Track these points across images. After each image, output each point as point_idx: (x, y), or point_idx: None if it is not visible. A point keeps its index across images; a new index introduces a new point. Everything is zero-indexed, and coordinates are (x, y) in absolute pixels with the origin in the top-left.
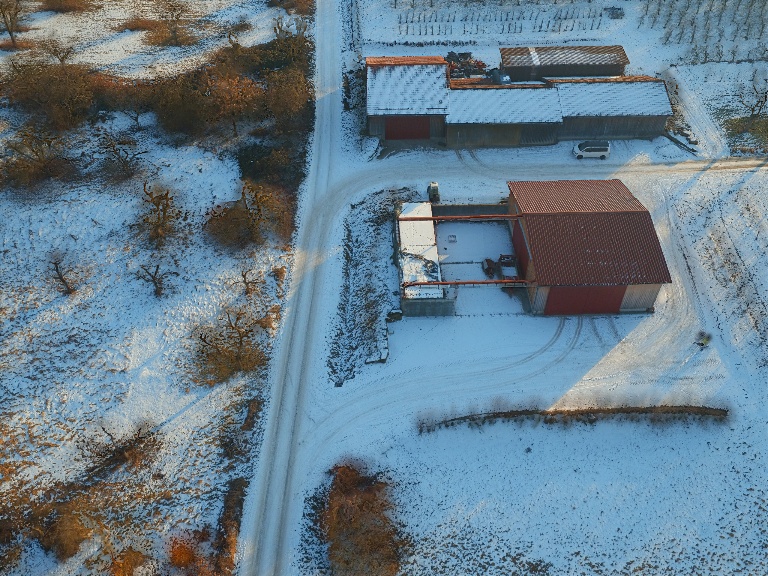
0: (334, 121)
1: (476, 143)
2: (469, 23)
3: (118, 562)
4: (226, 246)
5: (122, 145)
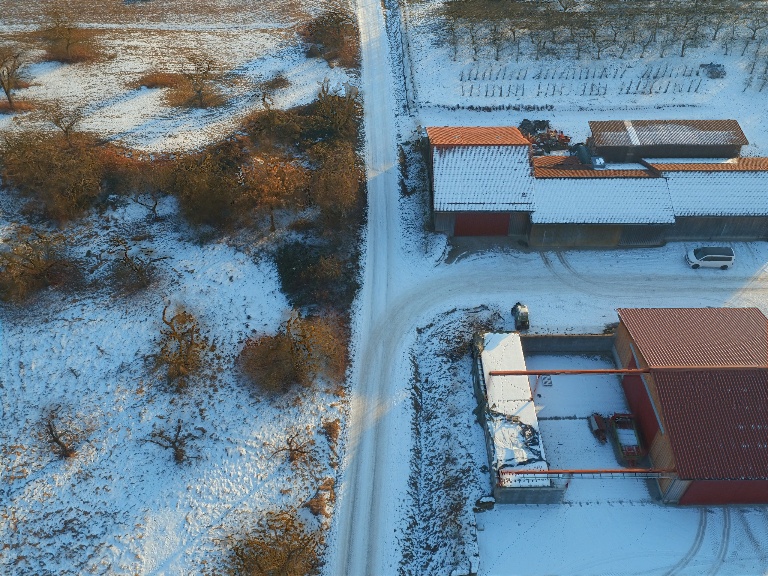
0: (390, 210)
1: (565, 244)
2: (542, 81)
3: None
4: (264, 389)
5: (136, 242)
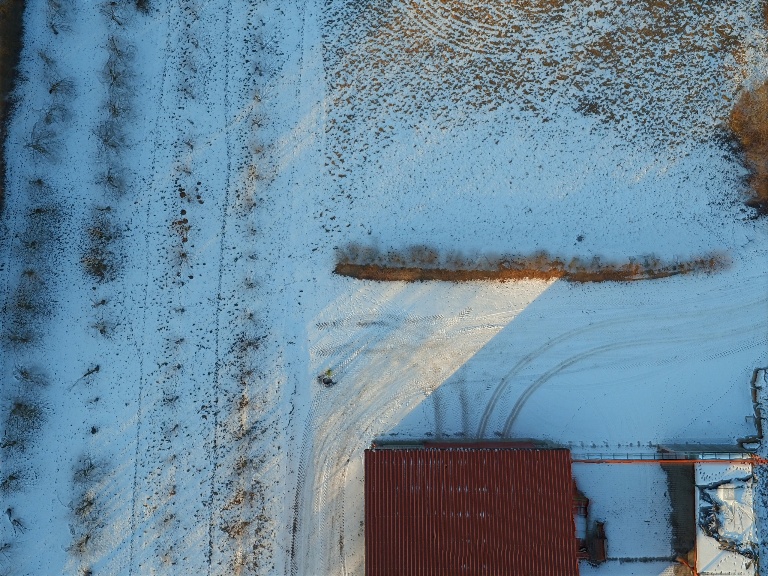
0: None
1: None
2: None
3: None
4: None
5: None
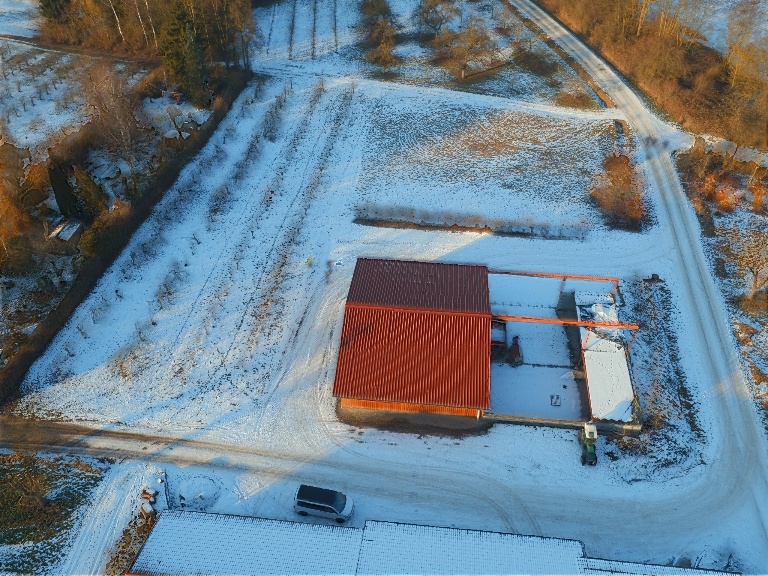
0: None
1: None
2: None
3: (766, 212)
4: None
5: None
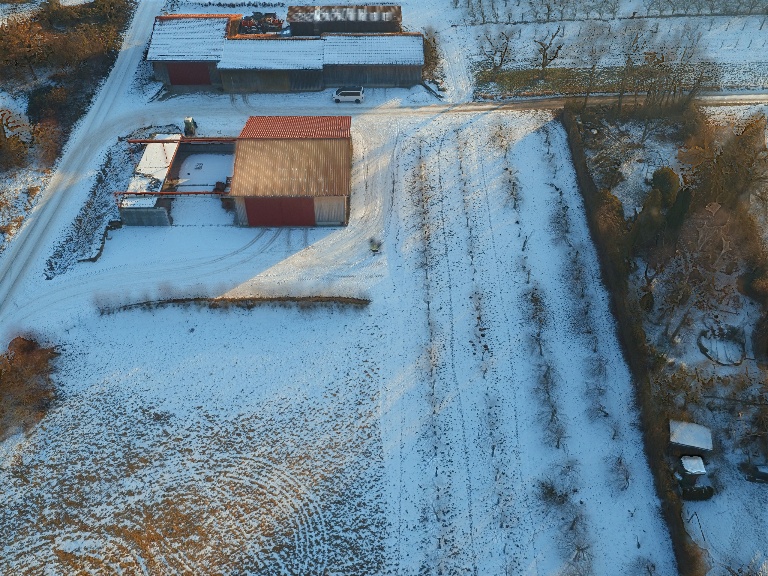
0: (130, 69)
1: (250, 88)
2: None
3: None
4: None
5: None
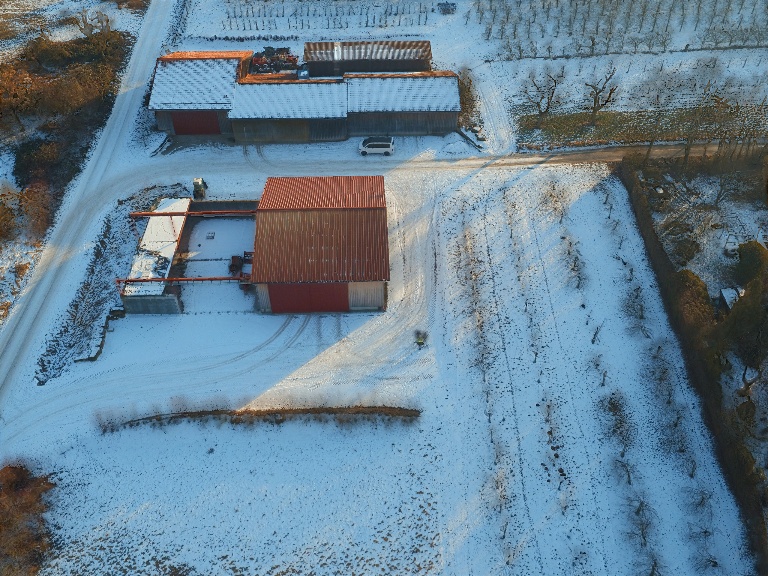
0: (129, 116)
1: (265, 139)
2: None
3: None
4: None
5: None
